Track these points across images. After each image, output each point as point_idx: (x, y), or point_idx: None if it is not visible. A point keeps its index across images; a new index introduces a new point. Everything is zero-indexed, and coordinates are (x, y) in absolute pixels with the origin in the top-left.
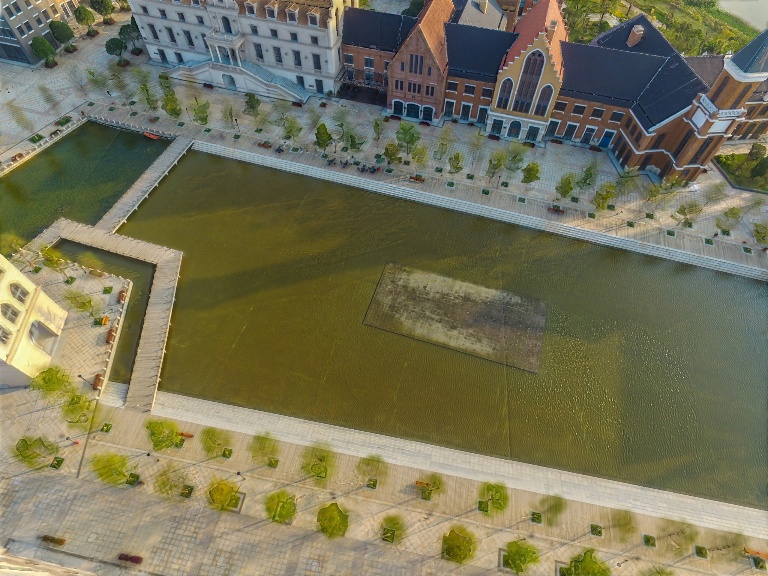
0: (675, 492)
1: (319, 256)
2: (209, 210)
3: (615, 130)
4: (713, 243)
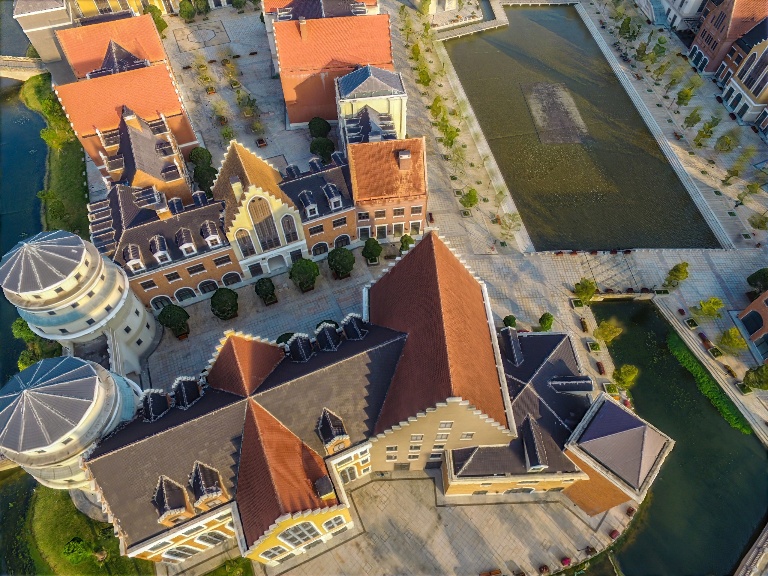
0: (512, 196)
1: (546, 61)
2: (541, 23)
3: None
4: (733, 216)
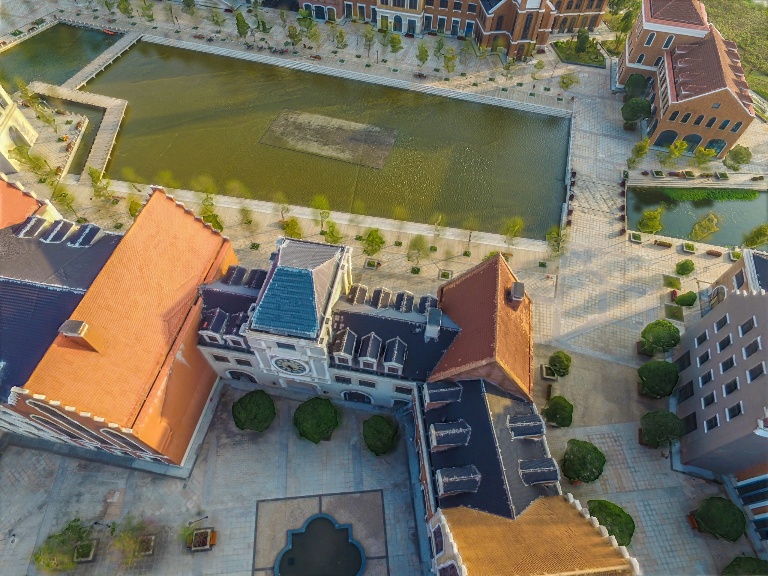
0: (461, 229)
1: (232, 105)
2: (151, 78)
3: (473, 21)
4: (535, 95)
